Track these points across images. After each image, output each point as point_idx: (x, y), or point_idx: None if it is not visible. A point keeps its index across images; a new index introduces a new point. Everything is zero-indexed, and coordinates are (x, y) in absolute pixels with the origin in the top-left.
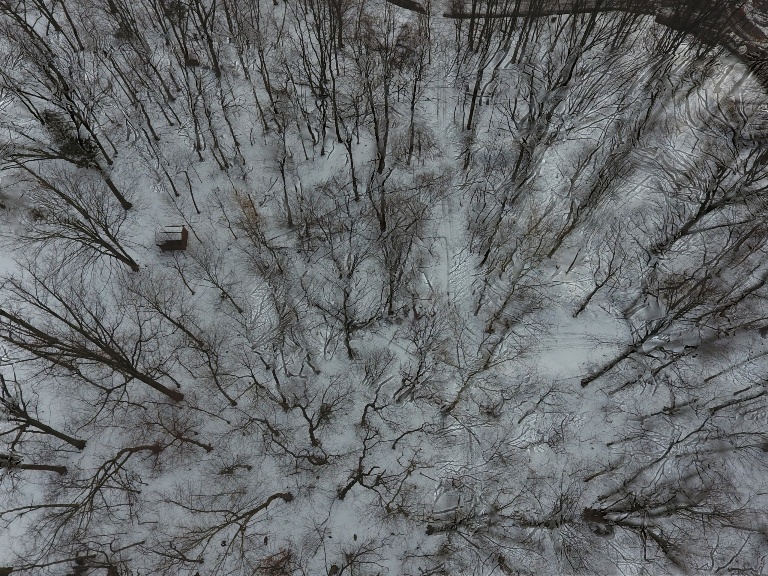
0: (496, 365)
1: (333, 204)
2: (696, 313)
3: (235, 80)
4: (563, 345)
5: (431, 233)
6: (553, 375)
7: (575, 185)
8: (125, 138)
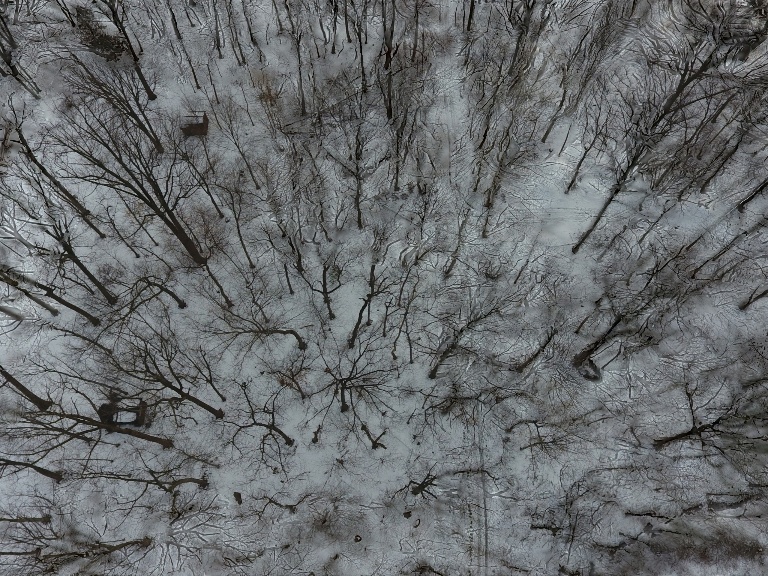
0: (494, 233)
1: (343, 95)
2: (678, 187)
3: None
4: (556, 218)
5: (434, 120)
6: (546, 242)
7: (567, 75)
8: (150, 37)
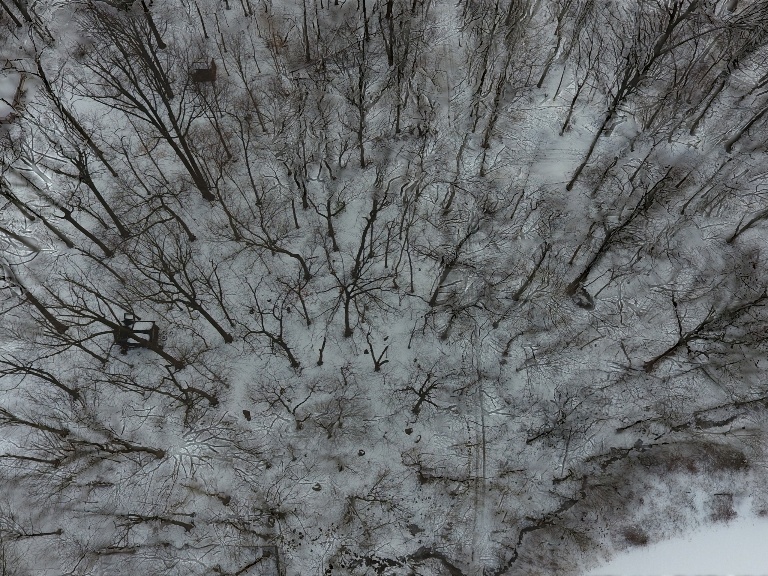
0: (491, 172)
1: (346, 43)
2: None
3: None
4: (551, 159)
5: (434, 66)
6: (542, 180)
7: (562, 23)
8: None
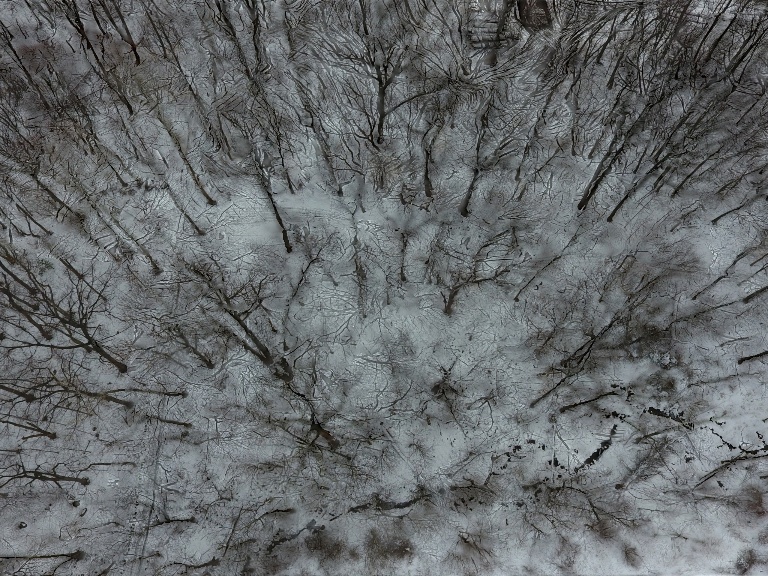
0: (211, 231)
1: (89, 90)
2: (398, 190)
3: None
4: None
5: (173, 117)
6: (261, 241)
7: None
8: None
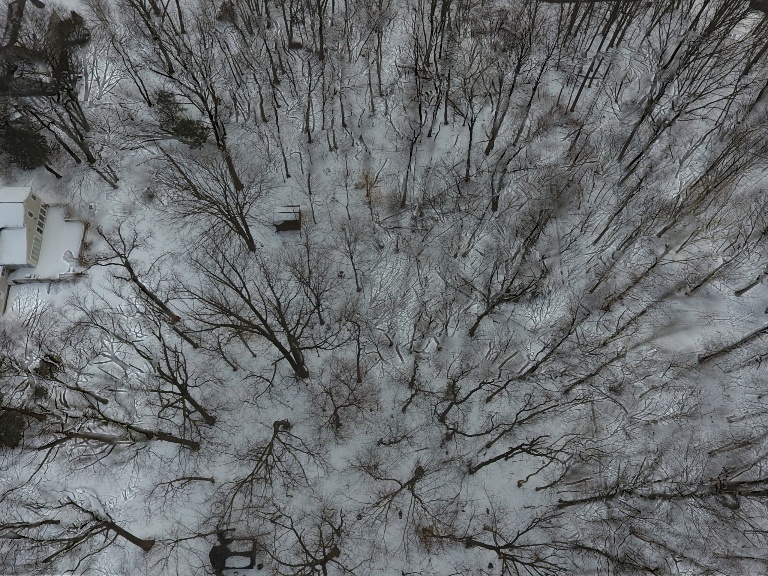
0: (614, 341)
1: (444, 184)
2: None
3: (339, 63)
4: (677, 322)
5: None
6: (671, 351)
7: (683, 165)
8: (234, 120)
